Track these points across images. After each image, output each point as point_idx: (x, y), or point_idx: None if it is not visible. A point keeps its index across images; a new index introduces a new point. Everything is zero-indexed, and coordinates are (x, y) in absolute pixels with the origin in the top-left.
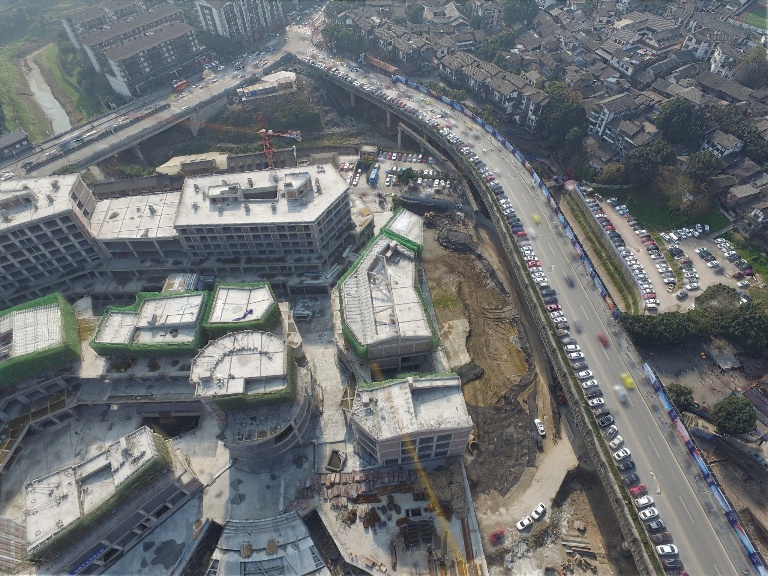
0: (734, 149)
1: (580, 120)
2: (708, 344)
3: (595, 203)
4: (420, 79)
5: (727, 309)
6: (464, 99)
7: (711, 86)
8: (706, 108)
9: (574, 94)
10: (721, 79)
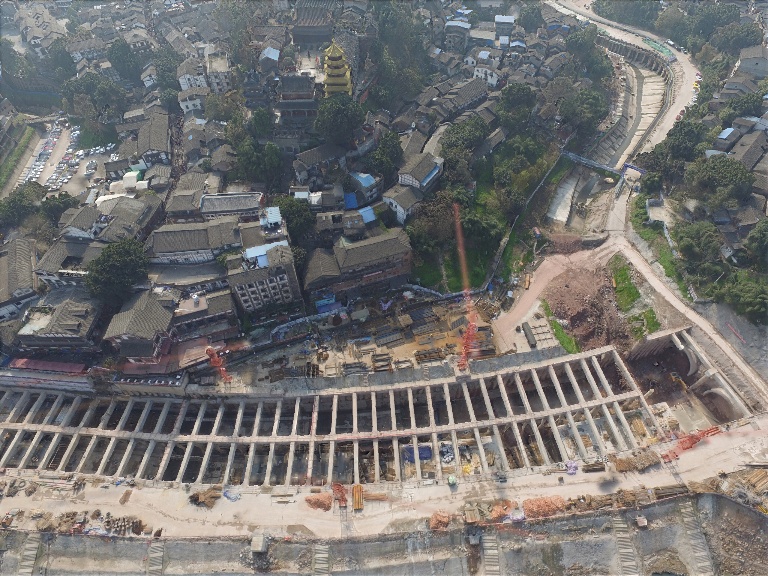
0: (154, 81)
1: (67, 61)
2: (14, 228)
3: (55, 130)
4: (2, 31)
5: (13, 197)
6: (5, 46)
7: (200, 32)
8: (149, 48)
9: (67, 38)
10: (207, 26)
